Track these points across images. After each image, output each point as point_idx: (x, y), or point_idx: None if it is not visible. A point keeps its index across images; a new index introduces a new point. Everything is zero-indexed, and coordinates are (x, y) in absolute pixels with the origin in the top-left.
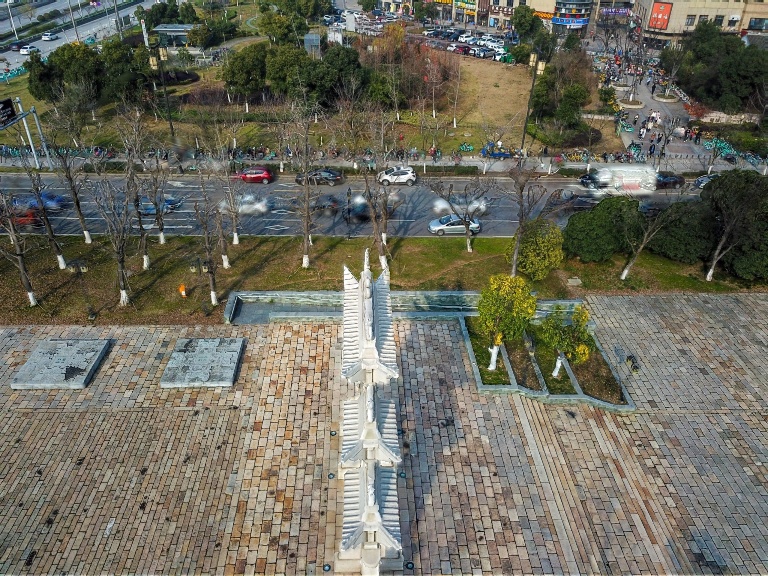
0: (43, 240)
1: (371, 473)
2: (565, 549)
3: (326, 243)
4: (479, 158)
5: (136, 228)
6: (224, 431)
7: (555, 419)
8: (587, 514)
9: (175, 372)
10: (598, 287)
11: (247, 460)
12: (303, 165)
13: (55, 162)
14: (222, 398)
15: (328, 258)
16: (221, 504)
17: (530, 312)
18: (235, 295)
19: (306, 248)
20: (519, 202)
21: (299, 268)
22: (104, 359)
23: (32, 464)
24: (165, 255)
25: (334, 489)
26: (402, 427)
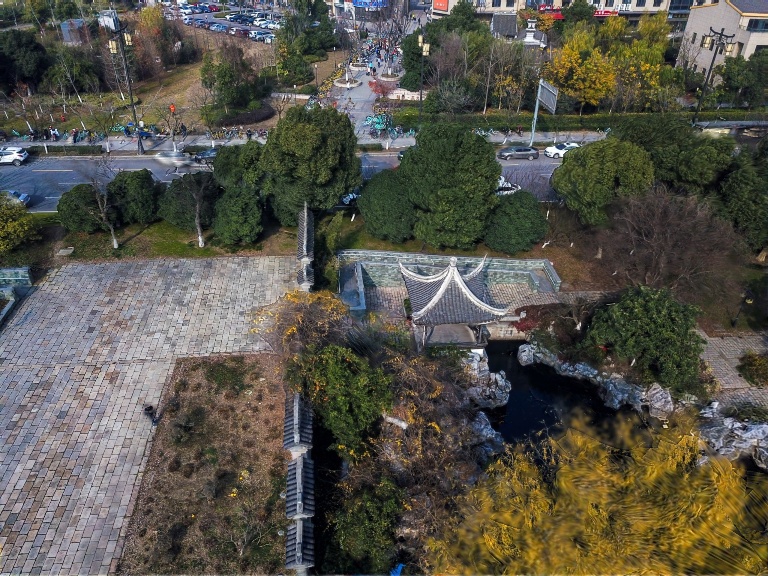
0: None
1: None
2: None
3: None
4: (123, 138)
5: None
6: None
7: None
8: None
9: None
10: (85, 256)
11: None
12: None
13: None
14: None
15: None
16: None
17: None
18: None
19: None
20: None
21: None
22: None
23: None
24: None
25: None
26: None
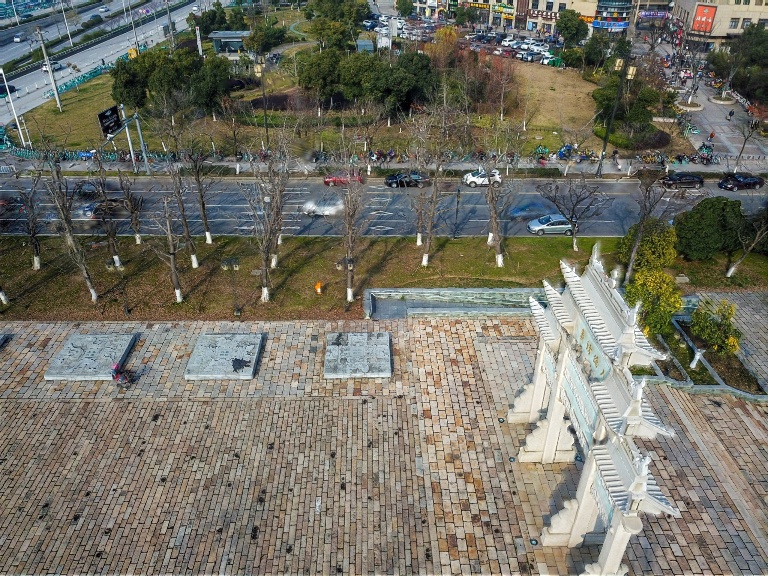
0: (165, 241)
1: (633, 447)
2: (751, 526)
3: (434, 243)
4: (556, 160)
5: (246, 229)
6: (396, 418)
7: (703, 408)
8: (758, 495)
9: (335, 364)
10: (706, 284)
11: (427, 445)
12: (421, 168)
13: (185, 166)
14: (384, 388)
15: (442, 257)
16: (415, 485)
17: (677, 306)
18: (369, 292)
19: (428, 247)
20: (640, 202)
21: (419, 266)
22: (262, 352)
23: (227, 448)
24: (286, 254)
25: (518, 471)
26: (565, 415)
